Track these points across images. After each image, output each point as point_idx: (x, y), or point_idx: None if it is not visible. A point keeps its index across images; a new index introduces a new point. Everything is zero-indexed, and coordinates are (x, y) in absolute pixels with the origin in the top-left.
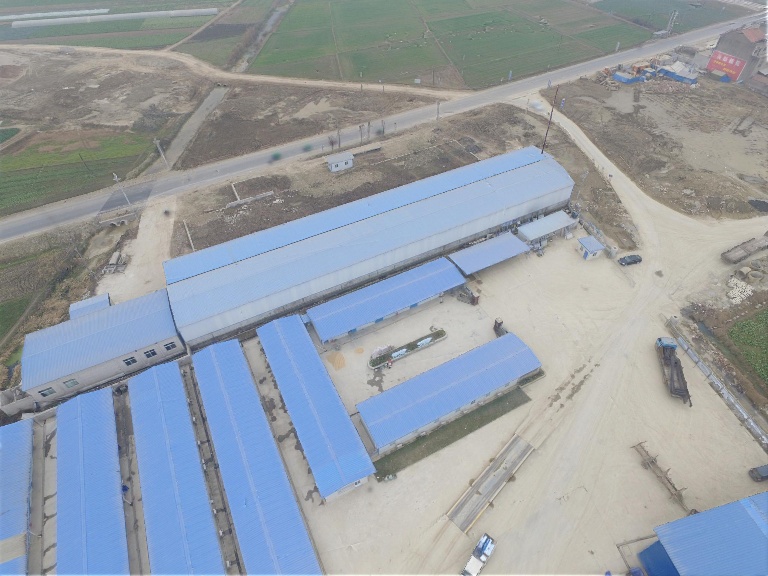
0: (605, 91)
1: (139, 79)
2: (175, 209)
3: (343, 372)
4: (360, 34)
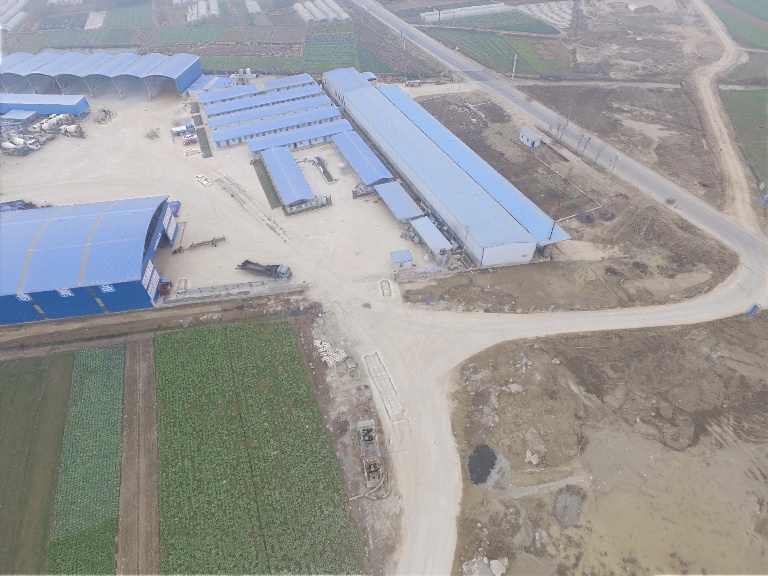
0: None
1: (666, 50)
2: (466, 91)
3: (315, 151)
4: None
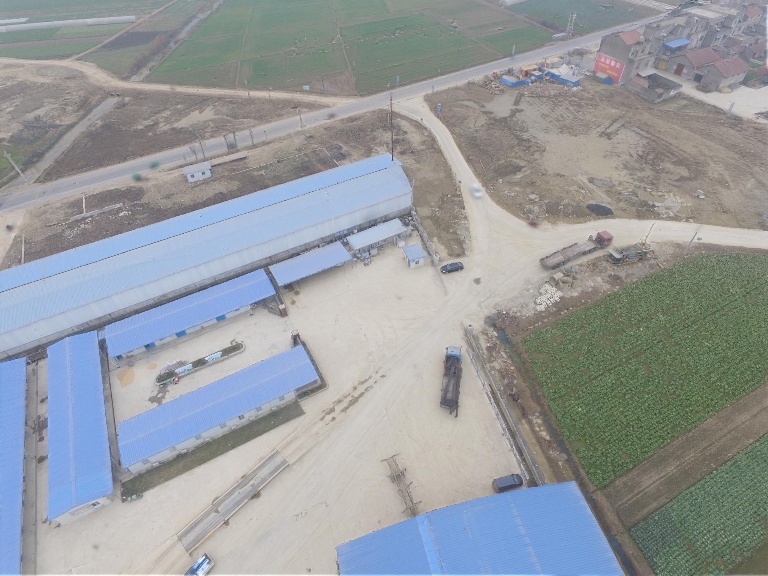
0: (488, 95)
1: (33, 90)
2: (20, 223)
3: (128, 389)
4: (270, 40)
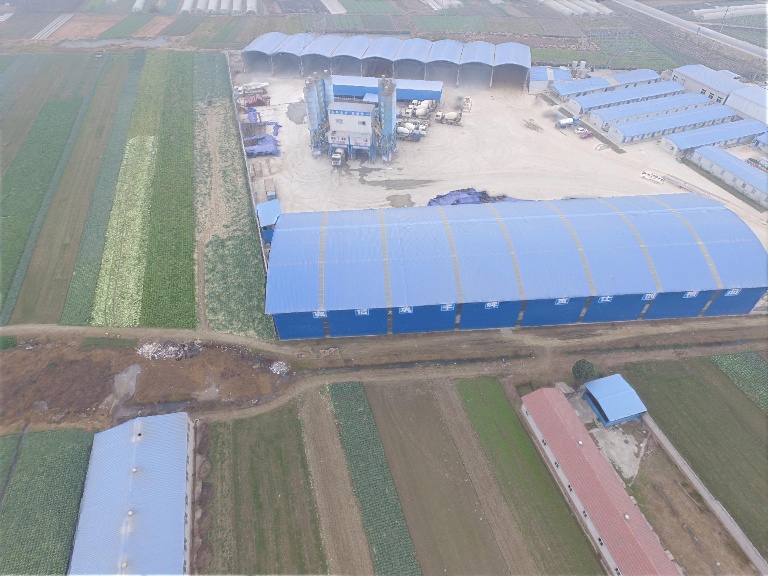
0: None
1: None
2: None
3: (737, 152)
4: None
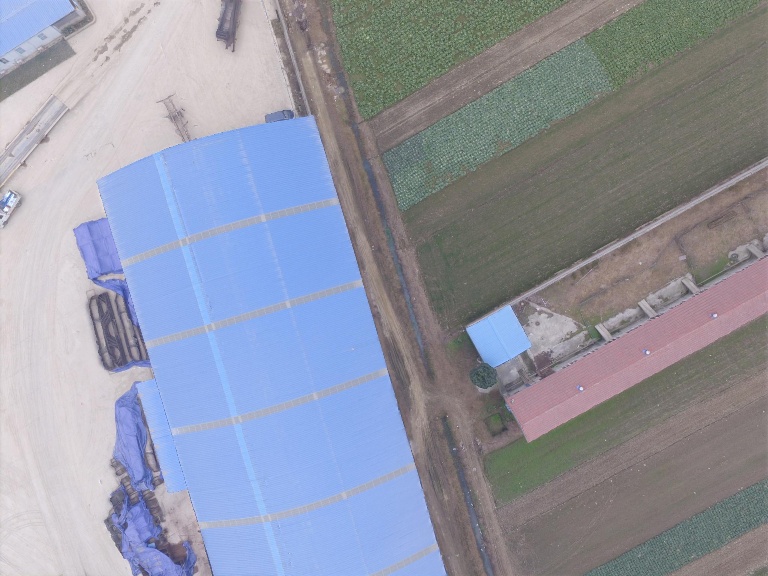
0: None
1: None
2: None
3: None
4: None
